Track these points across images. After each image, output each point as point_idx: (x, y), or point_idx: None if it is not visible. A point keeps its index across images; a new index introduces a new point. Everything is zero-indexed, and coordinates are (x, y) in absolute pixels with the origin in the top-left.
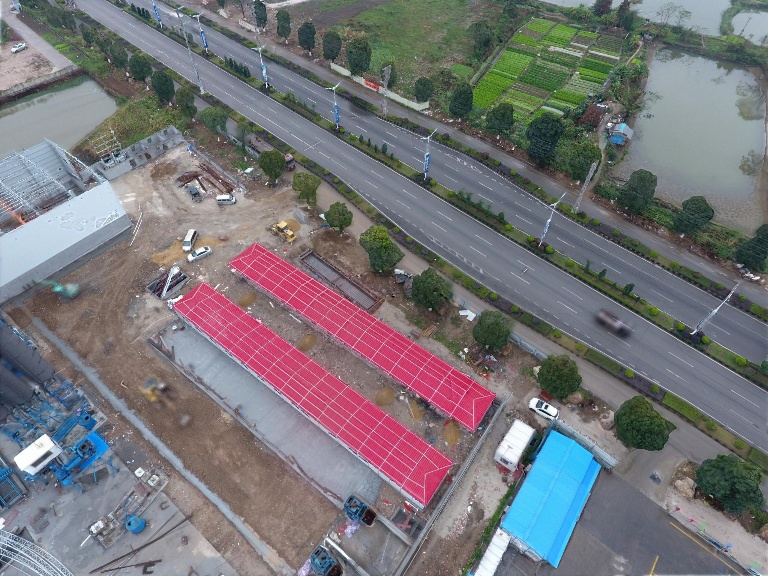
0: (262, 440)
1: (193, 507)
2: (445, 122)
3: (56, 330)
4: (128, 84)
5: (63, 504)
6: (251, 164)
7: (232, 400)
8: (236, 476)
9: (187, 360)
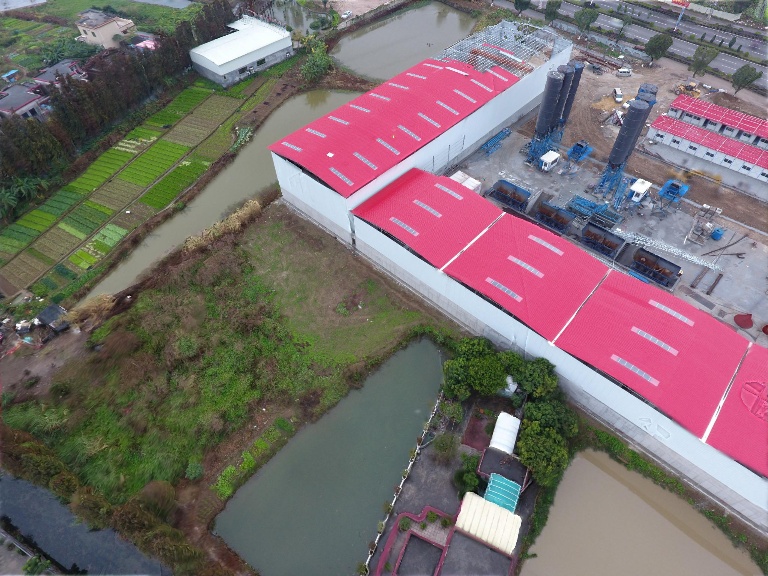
0: (767, 202)
1: (744, 232)
2: (761, 29)
3: (560, 142)
4: (472, 3)
5: (652, 225)
6: (619, 53)
7: (726, 182)
8: (762, 219)
9: (674, 160)
